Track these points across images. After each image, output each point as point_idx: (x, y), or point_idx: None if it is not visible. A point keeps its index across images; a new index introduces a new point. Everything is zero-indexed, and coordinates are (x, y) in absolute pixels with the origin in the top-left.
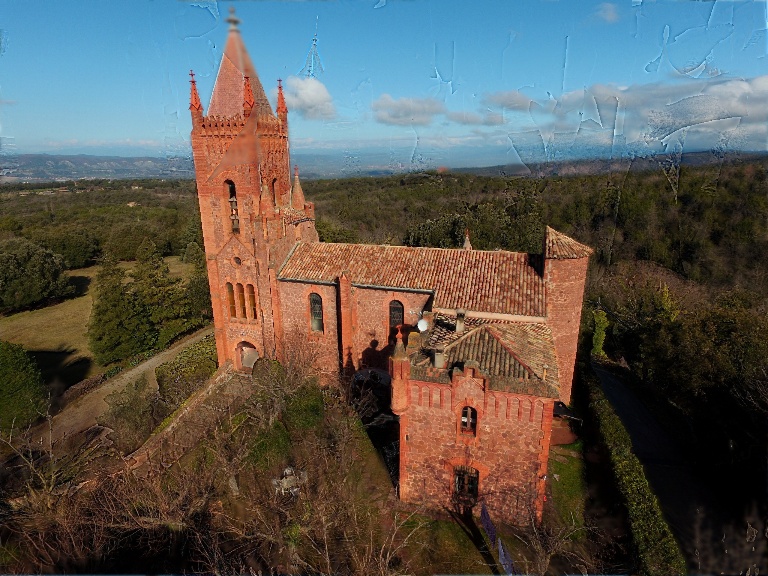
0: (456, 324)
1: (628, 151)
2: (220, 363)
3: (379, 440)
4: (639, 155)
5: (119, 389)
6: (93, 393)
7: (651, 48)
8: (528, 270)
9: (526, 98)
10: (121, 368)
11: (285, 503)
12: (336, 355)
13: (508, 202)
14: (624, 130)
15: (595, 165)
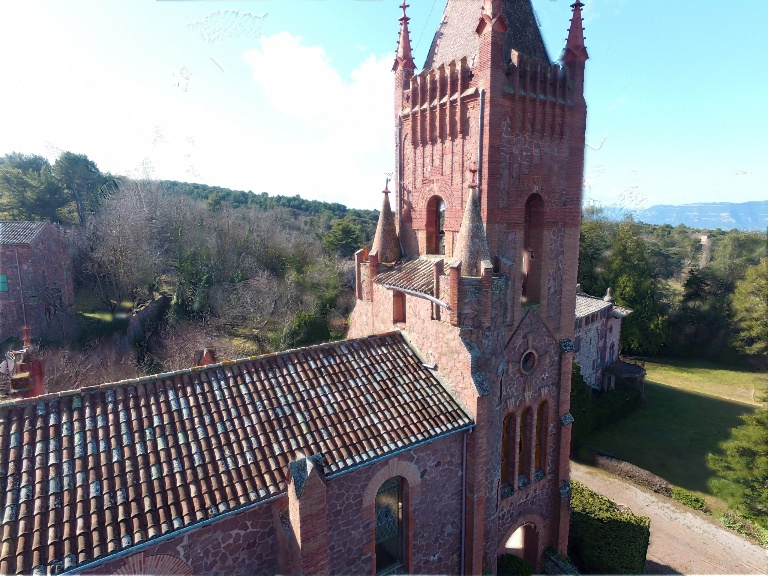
0: None
1: None
2: None
3: None
4: None
5: (630, 503)
6: (626, 485)
7: None
8: None
9: None
10: (707, 509)
11: None
12: None
13: None
14: None
15: None
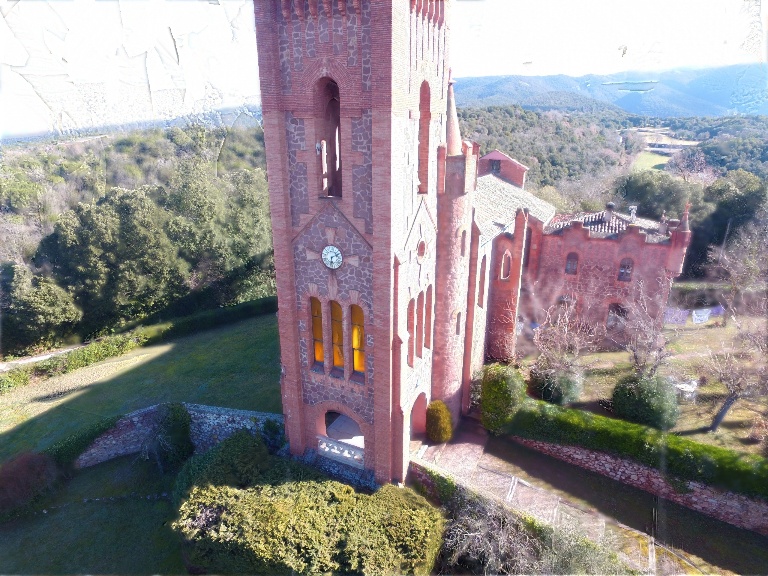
0: (608, 216)
1: (200, 108)
2: (404, 470)
3: (579, 352)
4: (174, 115)
5: None
6: None
7: (189, 1)
8: (510, 185)
9: (34, 23)
10: None
11: (701, 399)
12: (484, 327)
13: (9, 182)
14: (188, 85)
15: (177, 122)
